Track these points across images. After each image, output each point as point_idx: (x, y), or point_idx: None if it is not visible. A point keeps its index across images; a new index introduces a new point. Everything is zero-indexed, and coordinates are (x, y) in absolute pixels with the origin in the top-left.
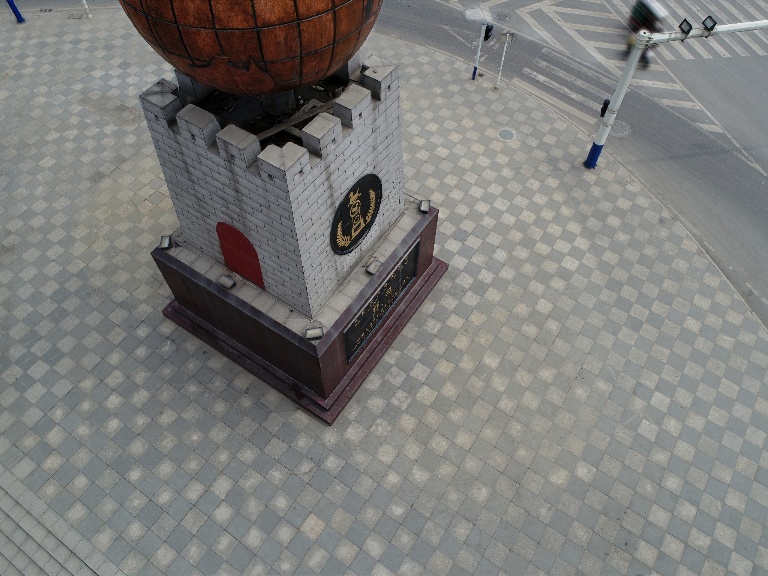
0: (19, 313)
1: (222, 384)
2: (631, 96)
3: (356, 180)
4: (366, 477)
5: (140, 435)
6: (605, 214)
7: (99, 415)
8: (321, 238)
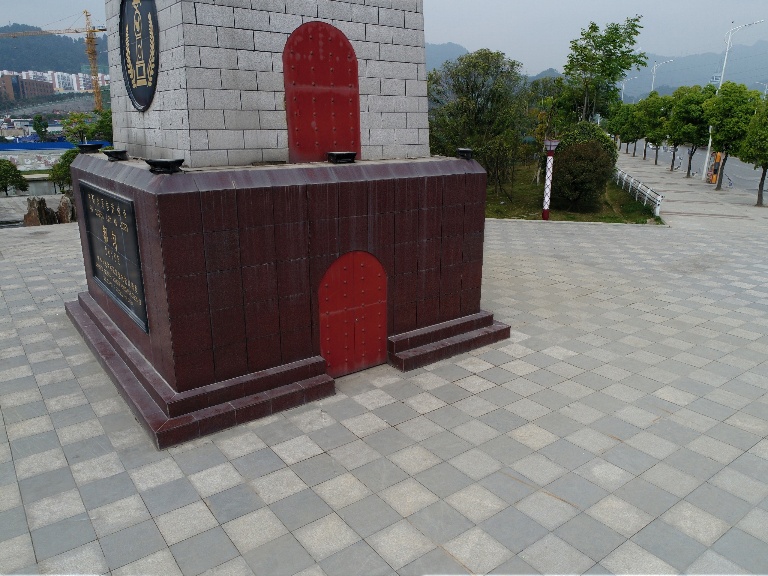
0: None
1: None
2: None
3: None
4: None
5: None
6: None
7: None
8: None
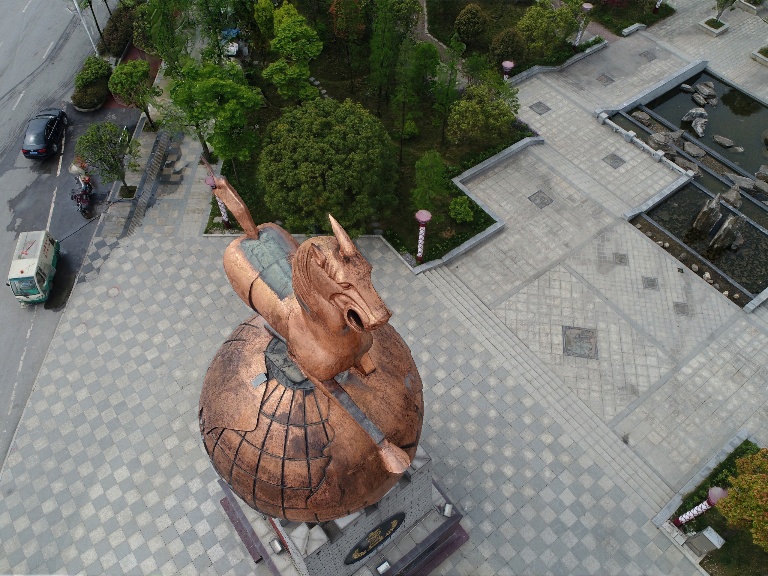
0: None
1: None
2: None
3: None
4: None
5: (489, 439)
6: (49, 517)
7: (518, 463)
8: None
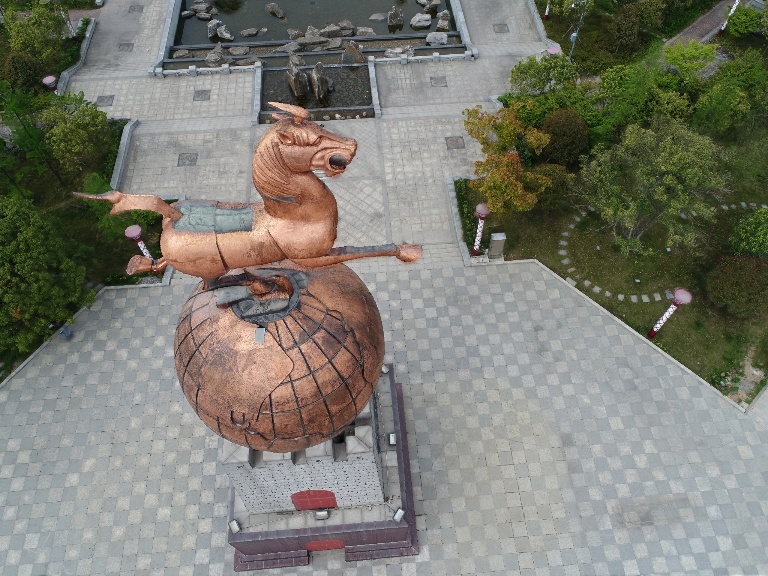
0: (481, 327)
1: None
2: None
3: None
4: None
5: None
6: None
7: None
8: None
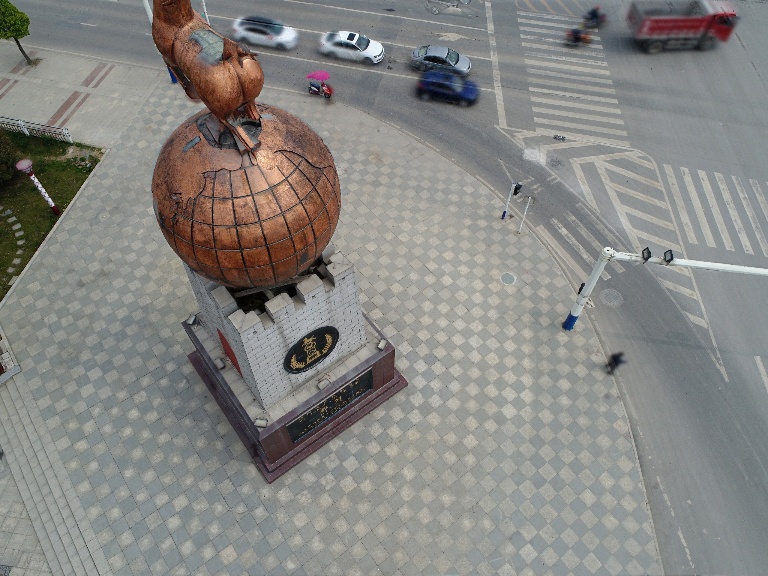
0: (96, 326)
1: (208, 425)
2: (637, 270)
3: (310, 331)
4: (279, 532)
5: (142, 445)
6: (560, 376)
7: (121, 421)
8: (274, 365)
